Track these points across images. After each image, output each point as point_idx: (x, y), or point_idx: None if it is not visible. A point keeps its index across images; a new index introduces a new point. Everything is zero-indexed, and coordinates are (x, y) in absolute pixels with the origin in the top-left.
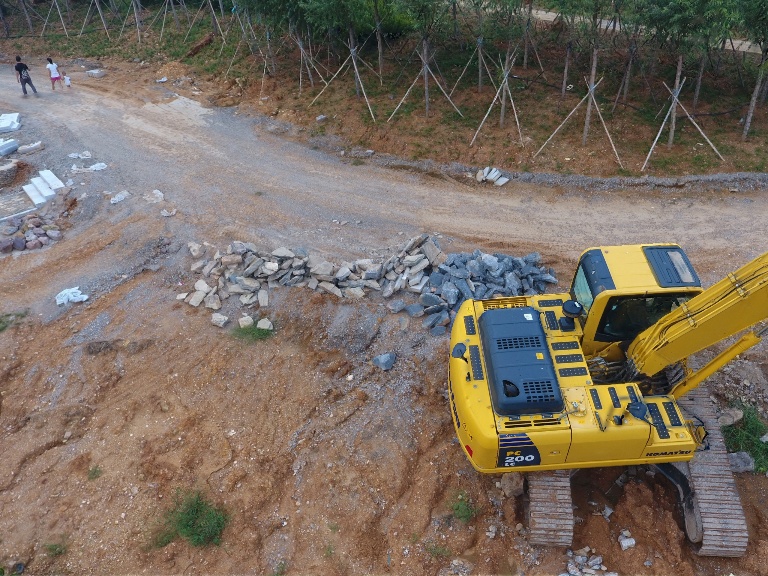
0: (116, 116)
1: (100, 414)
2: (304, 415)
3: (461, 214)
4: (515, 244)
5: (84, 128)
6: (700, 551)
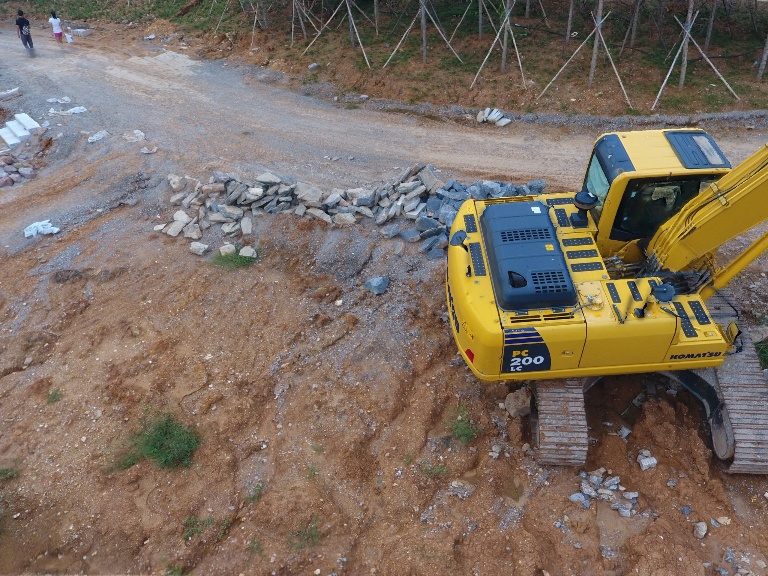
0: (100, 67)
1: (65, 340)
2: (288, 339)
3: (460, 151)
4: (518, 177)
5: (65, 77)
6: (731, 467)
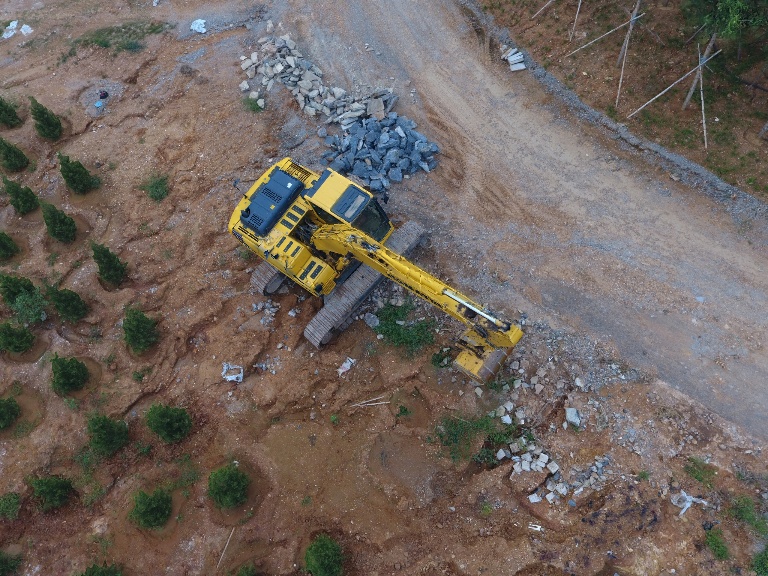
0: None
1: (164, 111)
2: (235, 167)
3: (451, 82)
4: (449, 128)
5: None
6: None
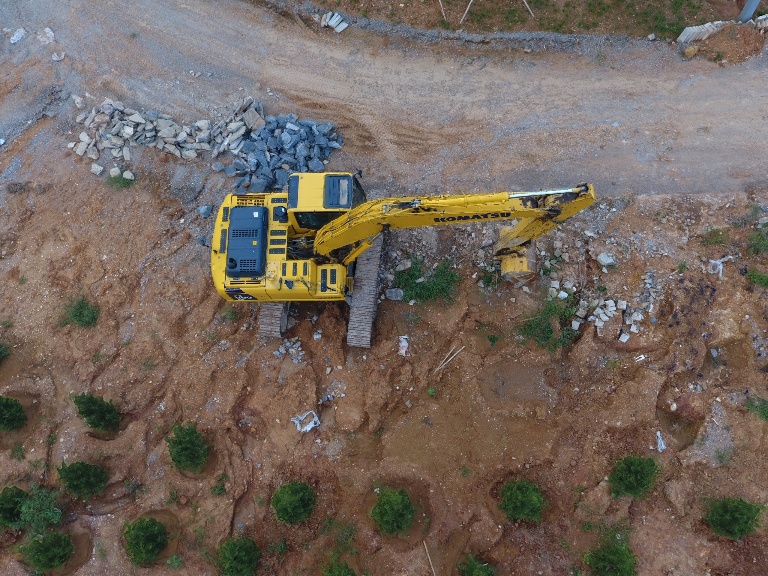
0: None
1: (22, 240)
2: (150, 247)
3: (296, 67)
4: (326, 105)
5: None
6: None
